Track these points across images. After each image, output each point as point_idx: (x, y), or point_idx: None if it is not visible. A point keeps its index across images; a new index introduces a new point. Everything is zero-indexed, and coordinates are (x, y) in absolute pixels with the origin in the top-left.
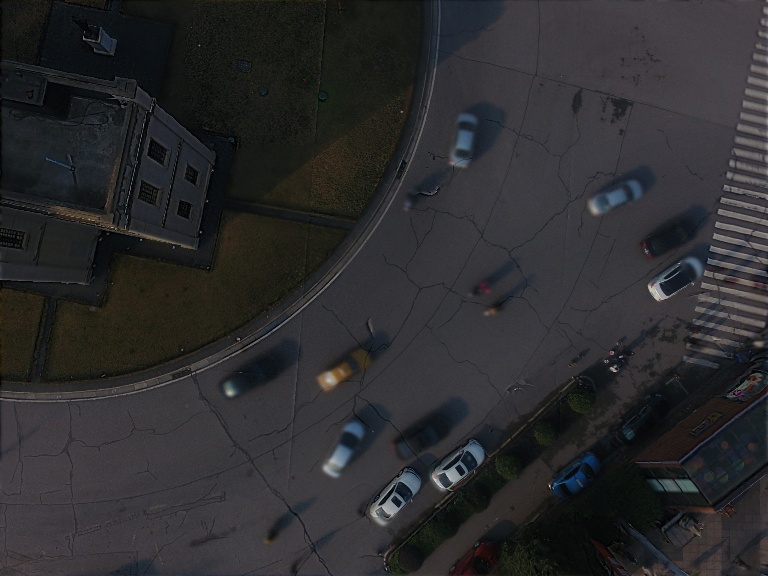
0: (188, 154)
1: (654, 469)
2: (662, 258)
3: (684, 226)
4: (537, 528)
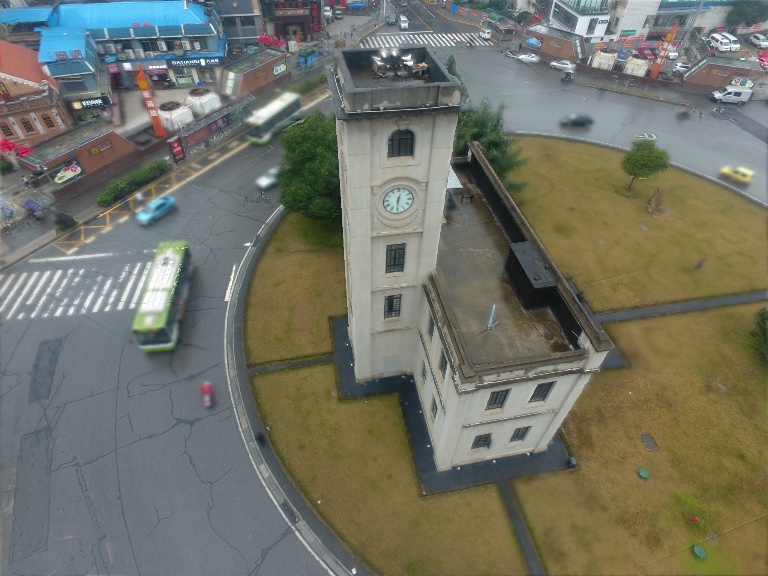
0: (542, 422)
1: None
2: None
3: None
4: None
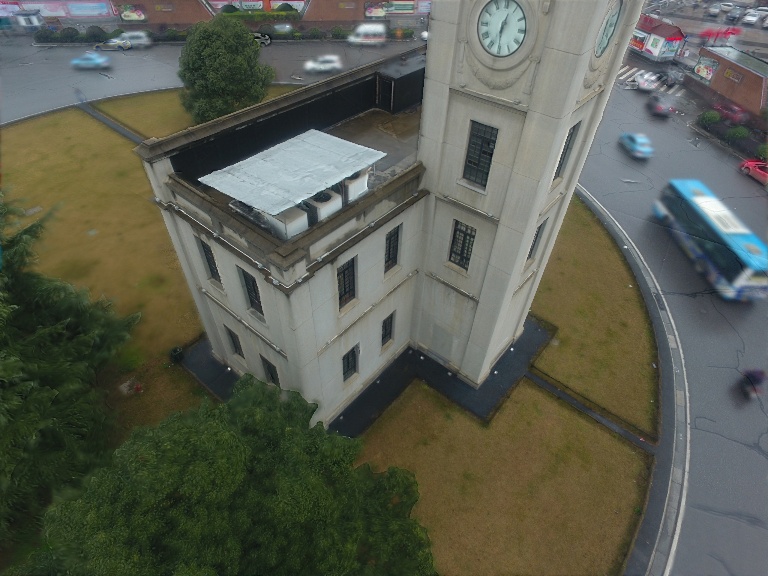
0: None
1: (767, 98)
2: None
3: None
4: None
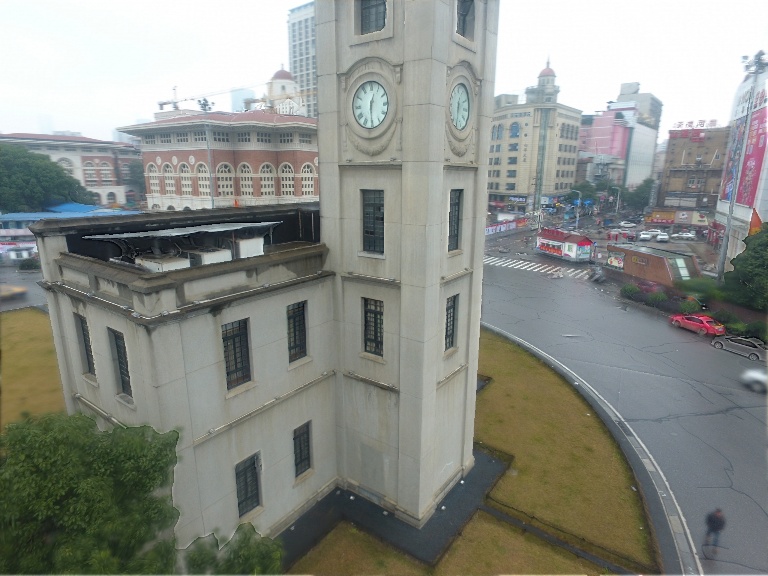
0: None
1: (674, 272)
2: None
3: None
4: (735, 291)
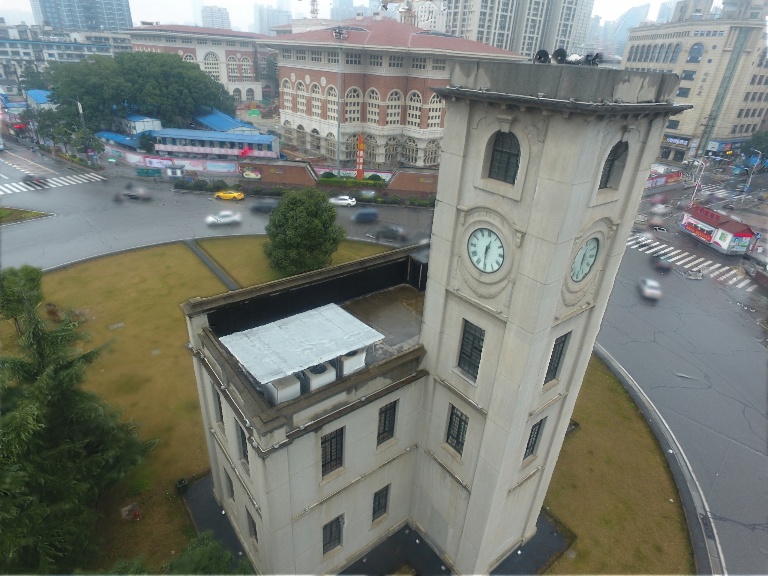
0: None
1: None
2: (669, 272)
3: (650, 261)
4: None
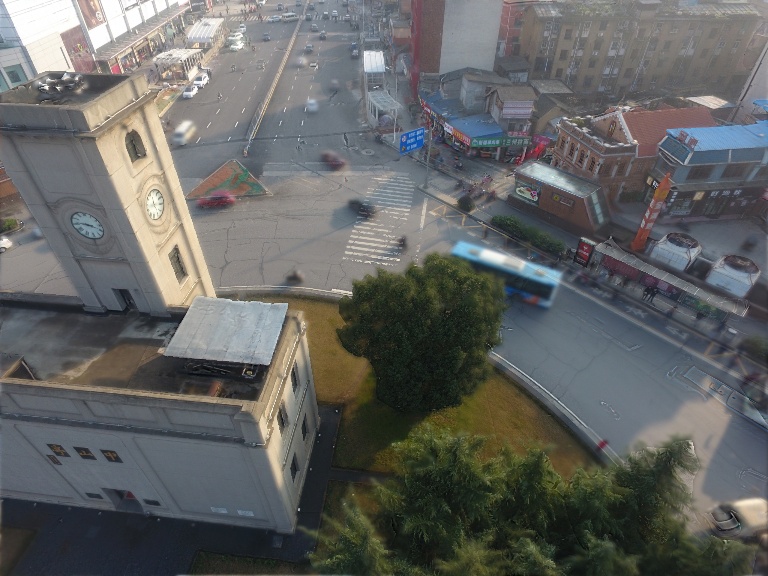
0: None
1: None
2: None
3: None
4: None
